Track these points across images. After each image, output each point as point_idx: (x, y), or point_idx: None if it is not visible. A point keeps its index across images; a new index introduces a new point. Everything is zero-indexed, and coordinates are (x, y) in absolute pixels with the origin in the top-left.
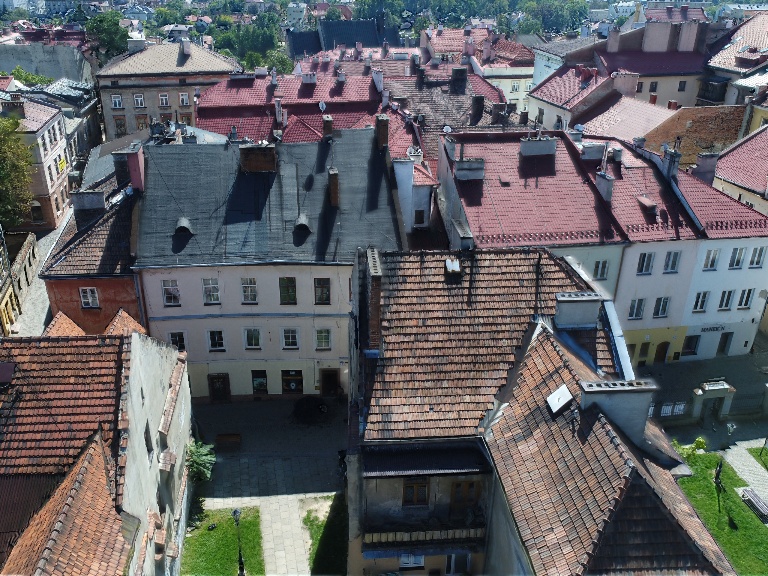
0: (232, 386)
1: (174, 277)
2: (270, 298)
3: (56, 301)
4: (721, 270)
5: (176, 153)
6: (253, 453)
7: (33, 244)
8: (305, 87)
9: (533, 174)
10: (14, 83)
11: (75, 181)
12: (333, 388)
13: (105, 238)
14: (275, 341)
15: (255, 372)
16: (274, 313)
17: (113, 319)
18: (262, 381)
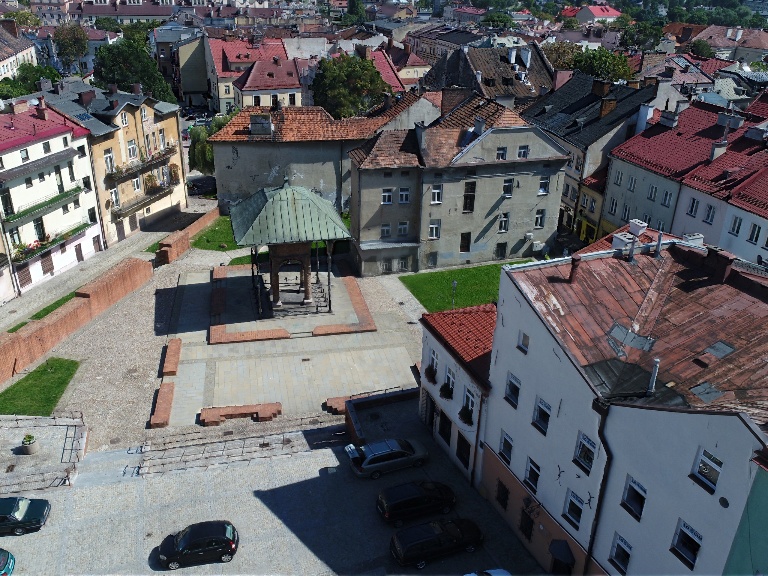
0: None
1: None
2: None
3: None
4: (741, 238)
5: None
6: None
7: None
8: None
9: (704, 135)
10: None
11: None
12: None
13: None
14: None
15: None
16: None
17: None
18: None
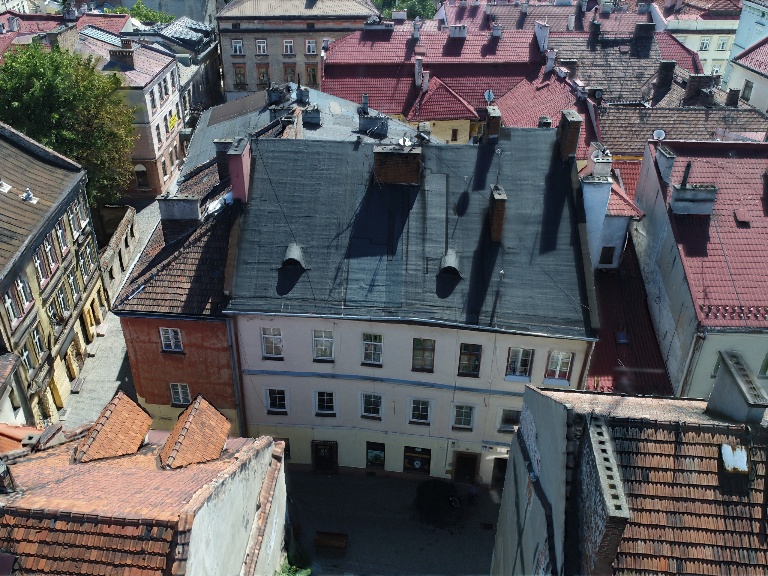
0: (340, 456)
1: (277, 325)
2: (398, 361)
3: (131, 340)
4: None
5: (291, 151)
6: (361, 564)
7: (132, 221)
8: (452, 42)
9: None
10: (131, 22)
11: (186, 140)
12: (469, 474)
13: (195, 263)
14: (400, 412)
15: (370, 443)
16: (402, 379)
17: (188, 408)
18: (378, 454)
